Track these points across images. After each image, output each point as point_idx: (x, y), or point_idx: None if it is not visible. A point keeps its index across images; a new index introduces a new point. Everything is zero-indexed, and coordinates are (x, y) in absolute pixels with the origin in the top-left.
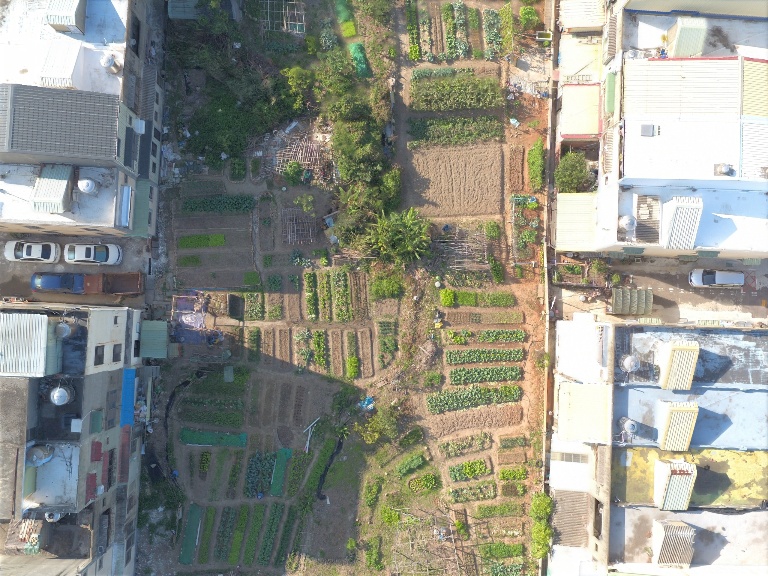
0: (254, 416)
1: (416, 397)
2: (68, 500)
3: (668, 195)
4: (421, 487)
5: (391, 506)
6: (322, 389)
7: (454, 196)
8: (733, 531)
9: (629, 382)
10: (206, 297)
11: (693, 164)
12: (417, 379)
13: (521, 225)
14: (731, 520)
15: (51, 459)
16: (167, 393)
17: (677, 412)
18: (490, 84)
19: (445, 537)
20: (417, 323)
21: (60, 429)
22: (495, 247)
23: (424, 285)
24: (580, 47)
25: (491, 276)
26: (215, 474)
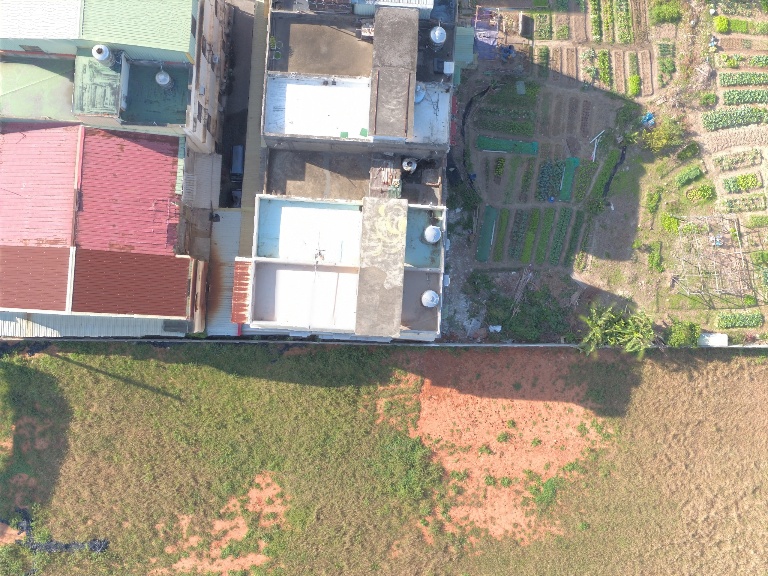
0: (545, 126)
1: (692, 115)
2: (435, 141)
3: None
4: (698, 197)
5: (670, 214)
6: (606, 104)
7: None
8: None
9: None
10: (499, 16)
11: None
12: (693, 99)
13: None
14: None
15: (420, 102)
16: (463, 104)
17: None
18: None
19: None
20: (693, 46)
21: (427, 75)
22: None
23: (699, 12)
24: None
25: (760, 6)
26: (509, 179)
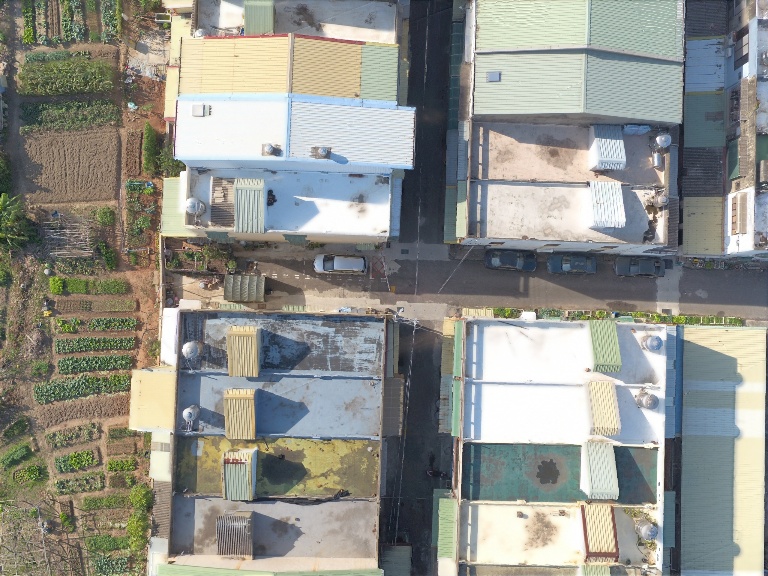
0: None
1: (24, 387)
2: None
3: (246, 177)
4: (26, 478)
5: None
6: None
7: (67, 182)
8: (308, 522)
9: (201, 369)
10: None
11: (238, 144)
12: (25, 368)
13: (137, 211)
14: (306, 510)
15: None
16: None
17: (232, 399)
18: (98, 67)
19: (34, 529)
20: (25, 311)
21: None
22: (108, 233)
23: (33, 273)
24: (188, 28)
25: (104, 263)
26: None
